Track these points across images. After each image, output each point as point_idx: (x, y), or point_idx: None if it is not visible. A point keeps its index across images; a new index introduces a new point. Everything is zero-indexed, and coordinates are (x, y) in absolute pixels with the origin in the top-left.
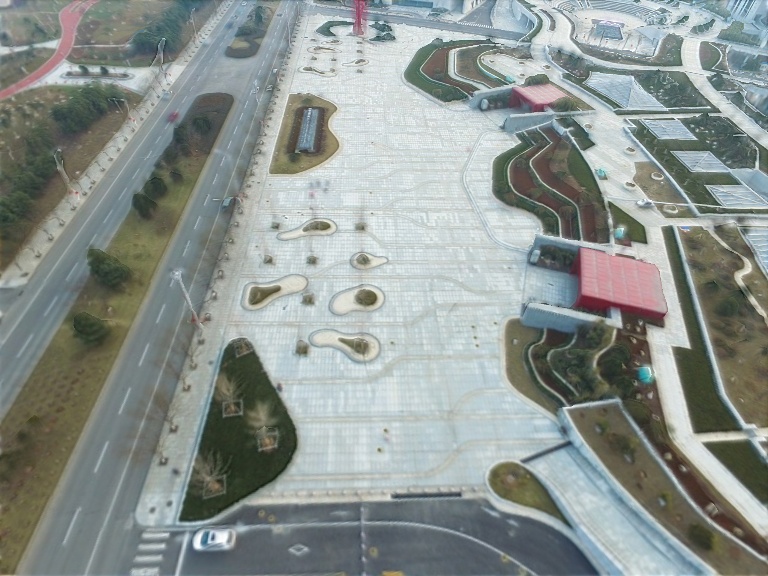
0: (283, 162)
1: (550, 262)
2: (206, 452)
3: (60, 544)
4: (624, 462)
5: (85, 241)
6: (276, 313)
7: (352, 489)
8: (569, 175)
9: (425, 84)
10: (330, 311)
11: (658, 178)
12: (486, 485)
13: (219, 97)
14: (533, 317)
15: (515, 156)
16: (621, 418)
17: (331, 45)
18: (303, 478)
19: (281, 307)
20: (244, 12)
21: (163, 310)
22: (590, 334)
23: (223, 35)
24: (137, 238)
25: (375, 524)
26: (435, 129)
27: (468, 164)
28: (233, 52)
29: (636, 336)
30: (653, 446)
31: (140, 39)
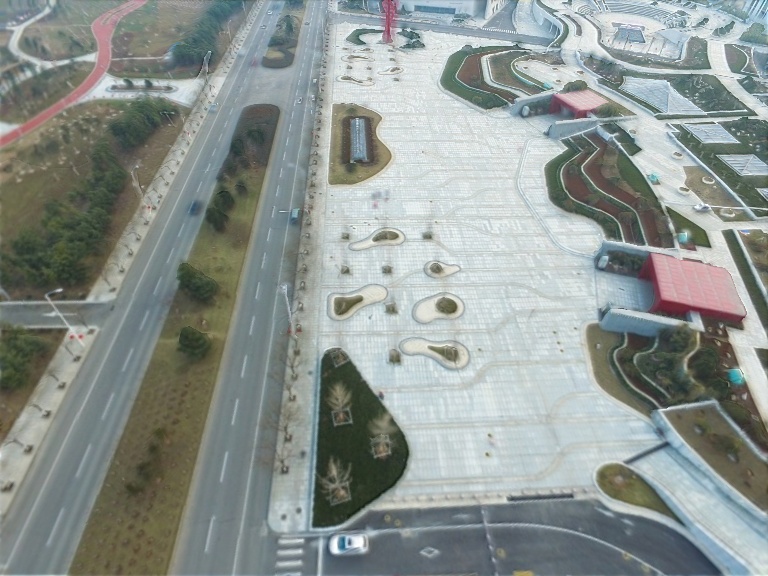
0: (340, 172)
1: (618, 267)
2: (325, 460)
3: (202, 552)
4: (728, 461)
5: (164, 255)
6: (363, 323)
7: (468, 493)
8: (622, 181)
9: (463, 91)
10: (414, 320)
11: (709, 182)
12: (595, 486)
13: (265, 108)
14: (614, 322)
15: (565, 162)
16: (720, 419)
17: (363, 53)
18: (420, 483)
19: (367, 317)
20: (272, 21)
21: (254, 322)
22: (674, 338)
23: (256, 45)
24: (215, 251)
25: (497, 526)
26: (481, 137)
27: (520, 171)
28: (270, 62)
29: (719, 339)
30: (757, 445)
31: (180, 51)
